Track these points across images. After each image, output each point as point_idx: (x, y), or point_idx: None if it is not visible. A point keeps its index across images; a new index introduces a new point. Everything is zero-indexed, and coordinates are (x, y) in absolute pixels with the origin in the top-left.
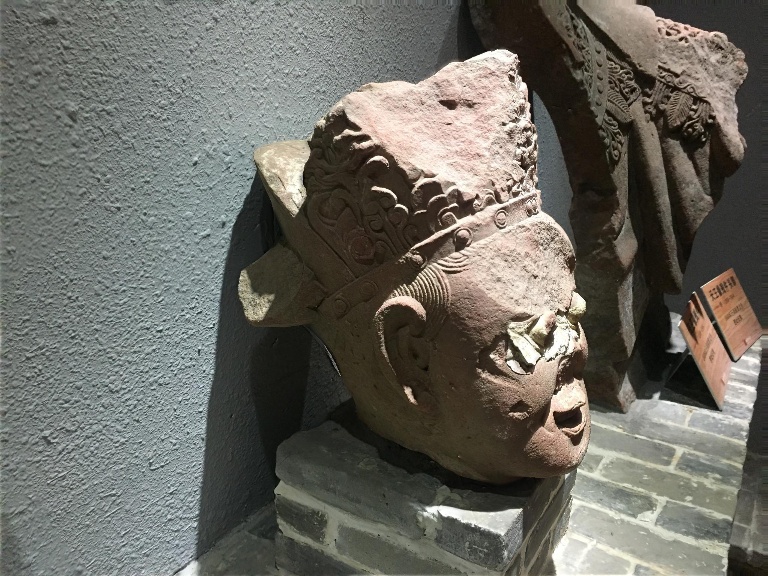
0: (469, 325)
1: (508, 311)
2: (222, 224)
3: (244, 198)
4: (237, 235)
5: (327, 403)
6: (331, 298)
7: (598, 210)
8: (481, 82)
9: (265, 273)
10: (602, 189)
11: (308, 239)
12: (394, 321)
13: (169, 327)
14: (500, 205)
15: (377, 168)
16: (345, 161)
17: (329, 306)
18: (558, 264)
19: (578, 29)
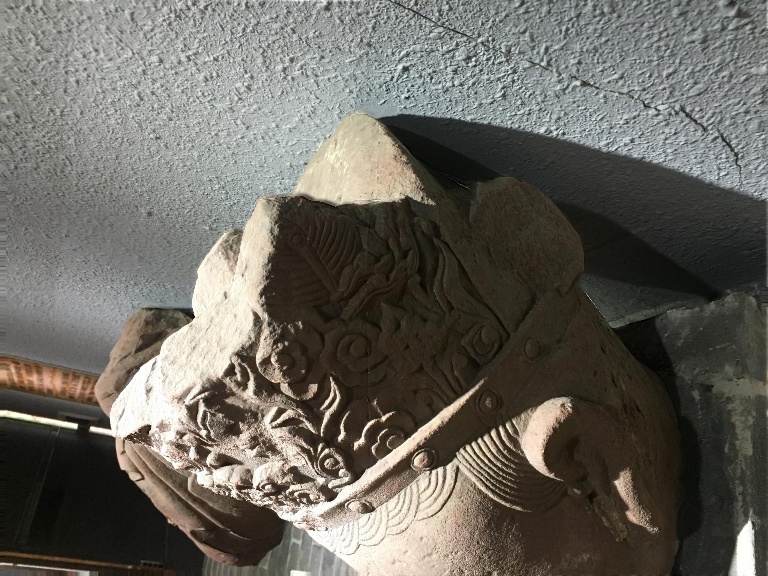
0: None
1: None
2: None
3: None
4: None
5: (725, 243)
6: None
7: None
8: None
9: None
10: None
11: None
12: None
13: None
14: None
15: None
16: None
17: None
18: None
19: None
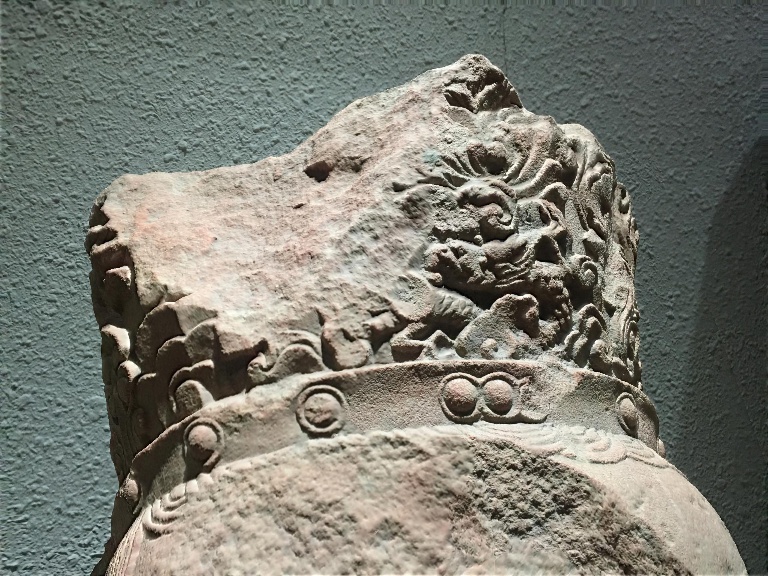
0: None
1: None
2: None
3: None
4: None
5: None
6: None
7: None
8: (391, 120)
9: None
10: None
11: None
12: None
13: (33, 566)
14: (325, 373)
15: (117, 289)
16: None
17: None
18: None
19: None
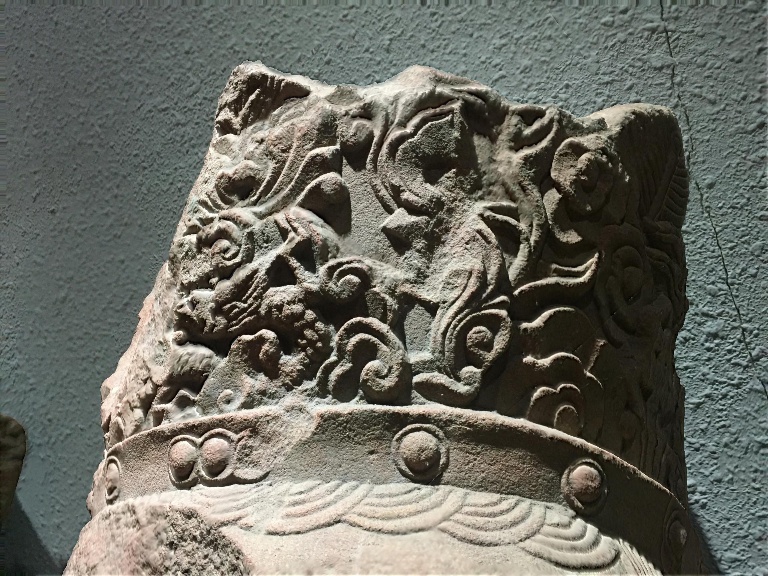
0: None
1: None
2: None
3: None
4: None
5: None
6: None
7: None
8: None
9: None
10: None
11: None
12: None
13: None
14: None
15: None
16: None
17: None
18: None
19: None
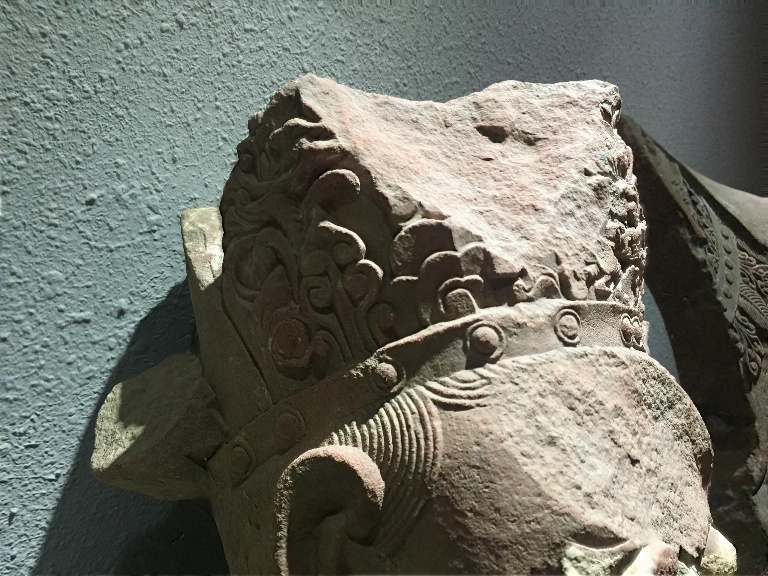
0: (473, 531)
1: (567, 514)
2: (118, 312)
3: (171, 286)
4: (144, 339)
5: None
6: (229, 443)
7: (726, 446)
8: (552, 112)
9: (147, 391)
10: (732, 416)
11: (215, 329)
12: (315, 495)
13: None
14: (568, 301)
15: (337, 189)
16: (284, 174)
17: (223, 459)
18: (680, 456)
19: (698, 206)
